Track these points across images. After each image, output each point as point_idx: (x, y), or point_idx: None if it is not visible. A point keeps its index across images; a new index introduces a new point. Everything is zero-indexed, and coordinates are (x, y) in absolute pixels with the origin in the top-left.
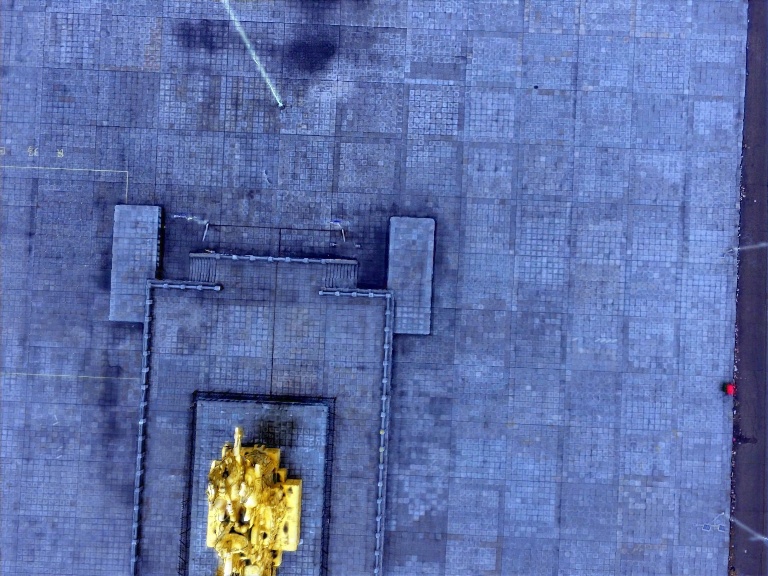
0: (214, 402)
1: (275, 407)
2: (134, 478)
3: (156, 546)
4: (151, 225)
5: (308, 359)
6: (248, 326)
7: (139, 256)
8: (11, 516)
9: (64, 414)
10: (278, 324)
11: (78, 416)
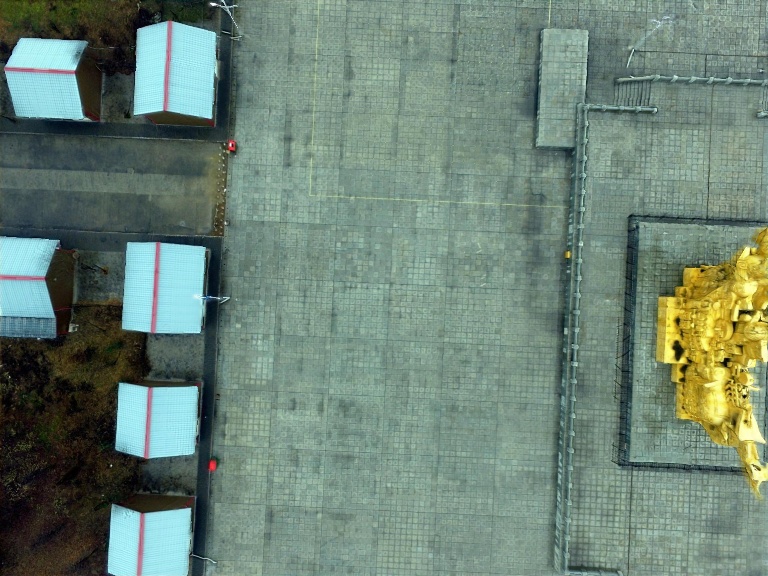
0: (656, 224)
1: (719, 228)
2: (558, 306)
3: (592, 370)
4: (581, 49)
5: (745, 183)
6: (683, 150)
7: (569, 80)
8: (436, 343)
9: (487, 242)
10: (714, 148)
11: (501, 244)
